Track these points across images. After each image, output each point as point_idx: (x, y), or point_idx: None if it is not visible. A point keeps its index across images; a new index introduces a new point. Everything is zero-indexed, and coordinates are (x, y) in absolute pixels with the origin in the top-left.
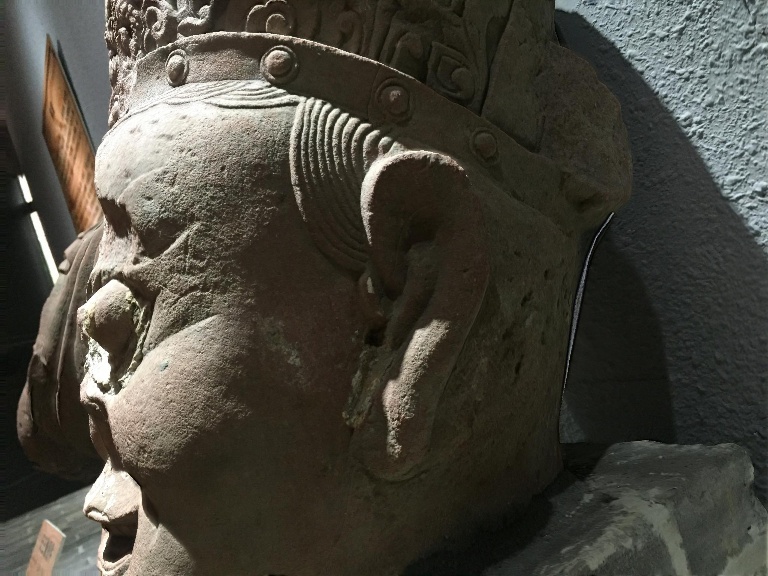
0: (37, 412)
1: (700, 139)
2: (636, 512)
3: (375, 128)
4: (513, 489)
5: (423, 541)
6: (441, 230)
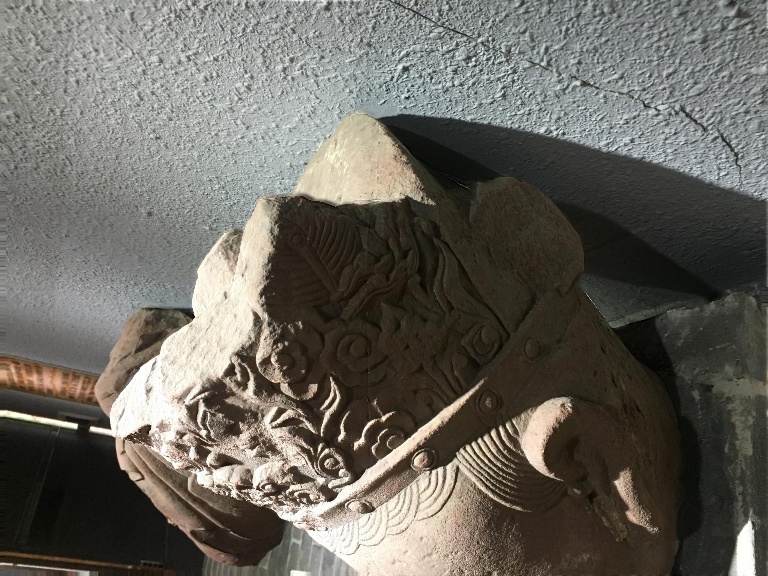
0: (229, 550)
1: (564, 135)
2: (735, 395)
3: (497, 426)
4: (674, 443)
5: (673, 517)
6: (582, 436)
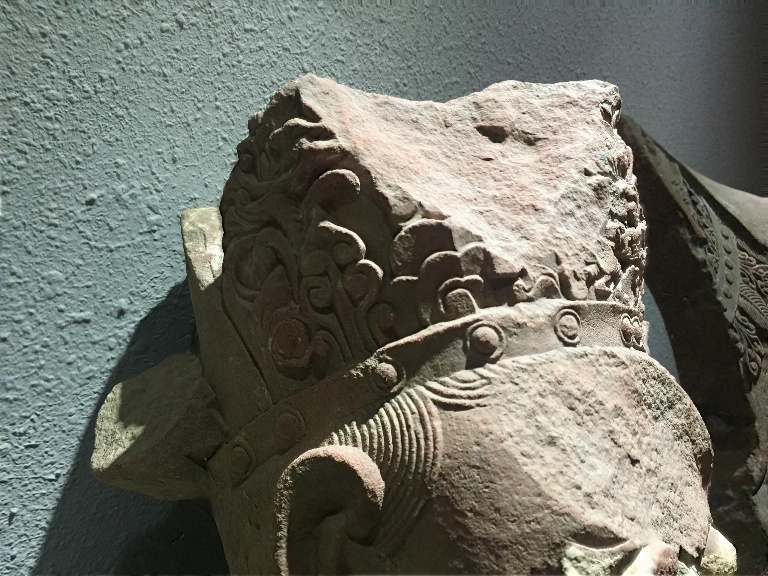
0: None
1: None
2: None
3: None
4: None
5: None
6: None
